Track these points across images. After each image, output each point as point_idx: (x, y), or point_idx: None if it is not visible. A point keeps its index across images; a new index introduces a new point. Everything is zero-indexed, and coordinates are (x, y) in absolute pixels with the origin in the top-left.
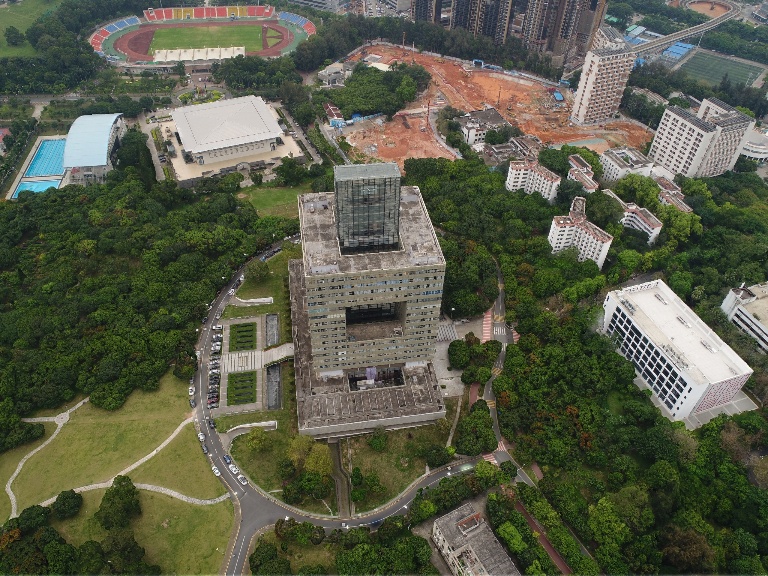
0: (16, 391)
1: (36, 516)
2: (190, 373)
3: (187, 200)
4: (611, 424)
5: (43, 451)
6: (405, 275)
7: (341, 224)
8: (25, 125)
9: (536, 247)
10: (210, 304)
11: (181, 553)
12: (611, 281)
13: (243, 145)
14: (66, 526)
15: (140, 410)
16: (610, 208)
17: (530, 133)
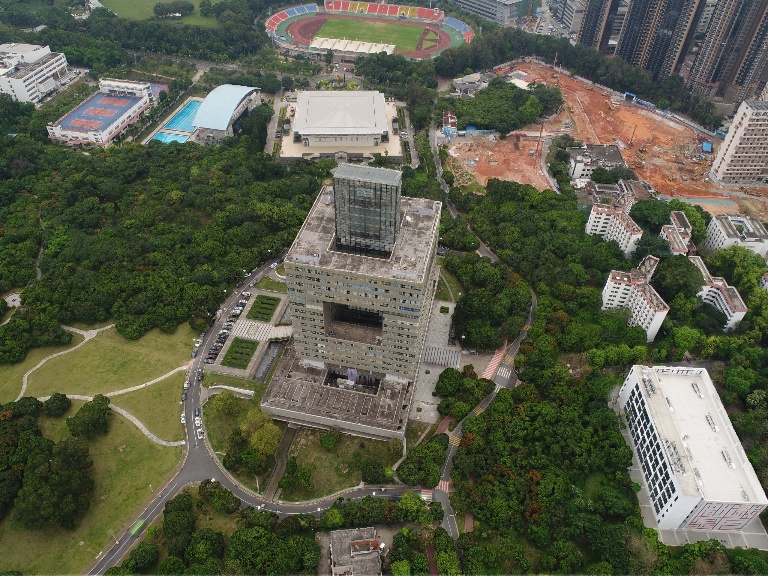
0: (65, 301)
1: (28, 406)
2: (202, 327)
3: (279, 175)
4: (574, 505)
5: (64, 356)
6: (380, 284)
7: (338, 220)
8: (180, 84)
9: (584, 298)
10: (250, 272)
11: (121, 478)
12: (654, 356)
13: (347, 135)
14: (49, 422)
15: (151, 346)
16: (686, 277)
17: (653, 180)
